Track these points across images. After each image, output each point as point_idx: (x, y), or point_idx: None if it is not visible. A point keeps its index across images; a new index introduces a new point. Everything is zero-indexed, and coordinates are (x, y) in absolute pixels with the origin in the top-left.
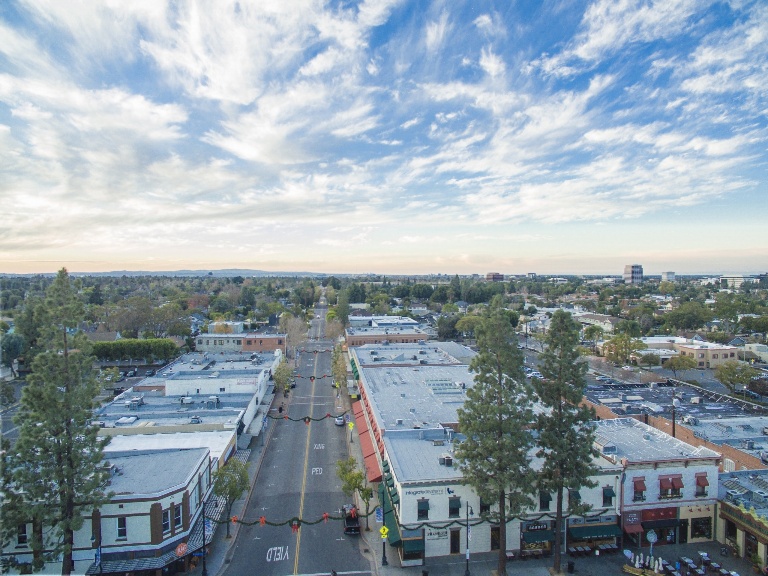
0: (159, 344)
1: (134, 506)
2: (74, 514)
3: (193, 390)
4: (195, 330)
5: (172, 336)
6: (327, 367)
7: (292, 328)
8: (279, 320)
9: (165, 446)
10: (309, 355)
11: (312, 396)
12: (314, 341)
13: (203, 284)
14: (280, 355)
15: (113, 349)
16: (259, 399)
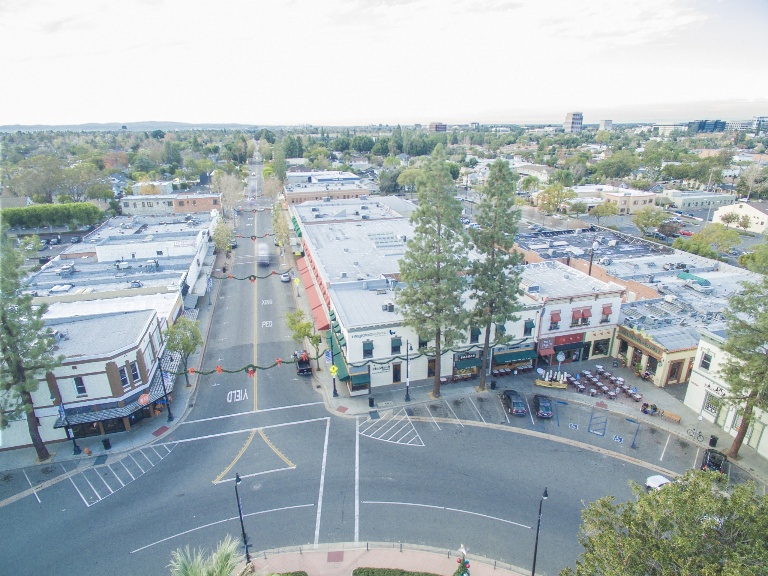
0: (79, 208)
1: (88, 366)
2: (27, 378)
3: (128, 255)
4: (118, 192)
5: (93, 199)
6: (268, 226)
7: (226, 187)
8: (211, 178)
9: (108, 310)
10: (248, 214)
11: (255, 255)
12: (252, 200)
13: (118, 140)
14: (217, 215)
15: (27, 216)
16: (200, 261)
